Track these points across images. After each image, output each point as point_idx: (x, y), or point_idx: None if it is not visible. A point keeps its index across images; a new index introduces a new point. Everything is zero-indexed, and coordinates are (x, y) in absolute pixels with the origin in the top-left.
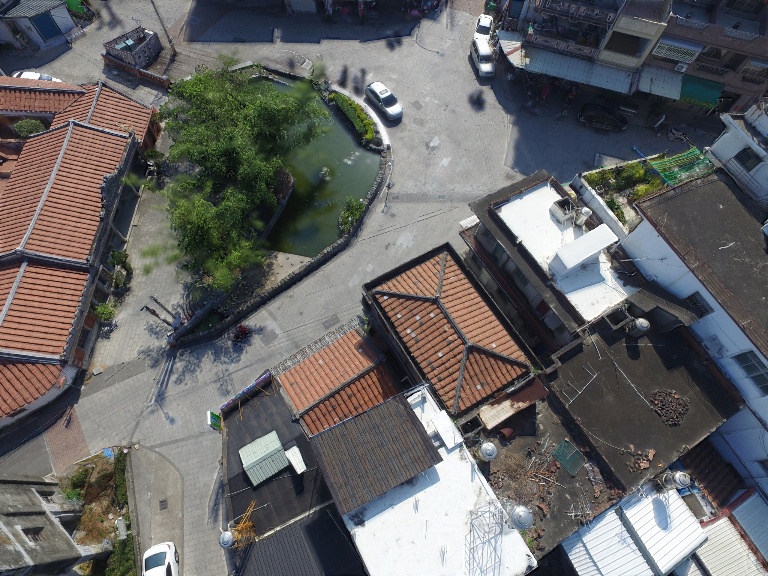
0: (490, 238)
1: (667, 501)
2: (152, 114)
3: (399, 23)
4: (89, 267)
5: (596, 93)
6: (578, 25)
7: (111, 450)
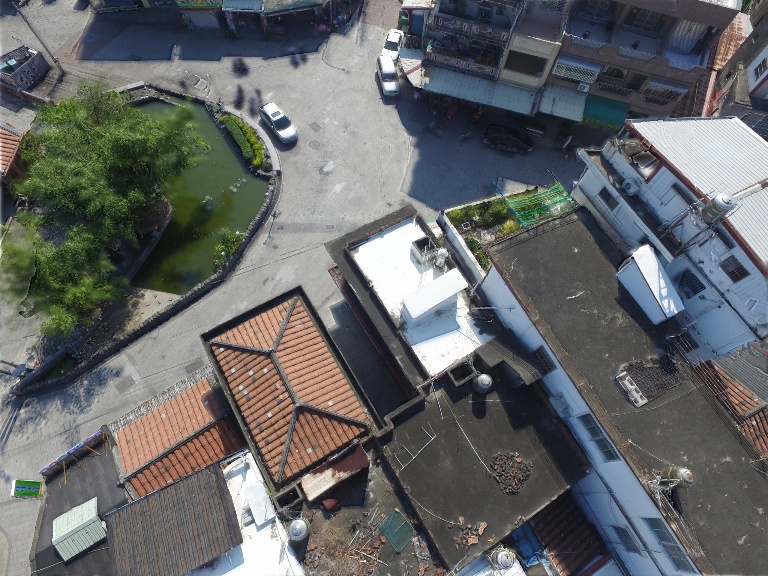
0: None
1: None
2: None
3: (306, 38)
4: None
5: (504, 112)
6: (477, 43)
7: None
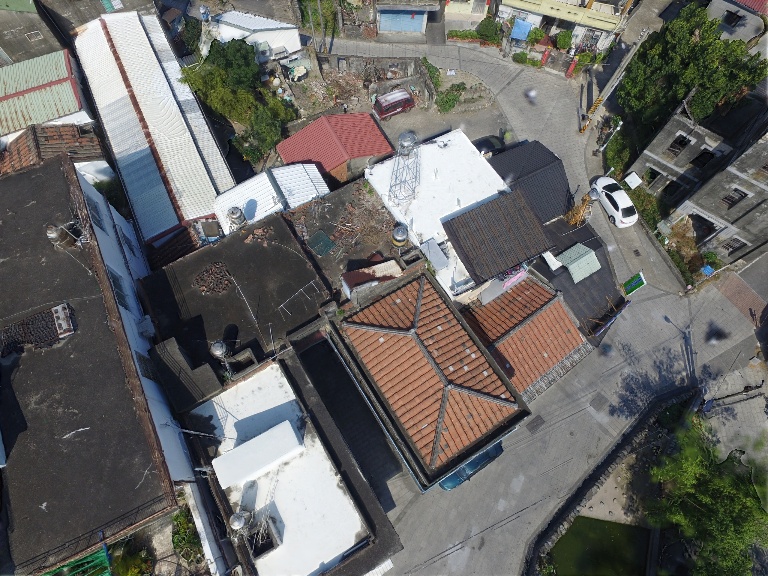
0: None
1: None
2: None
3: None
4: None
5: None
6: None
7: None
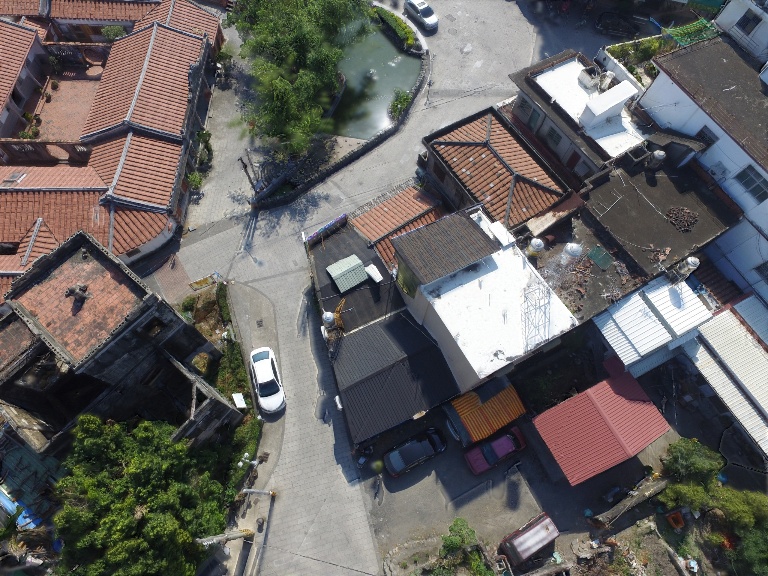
0: (526, 108)
1: (680, 290)
2: (219, 23)
3: None
4: (182, 140)
5: (611, 6)
6: None
7: (216, 278)
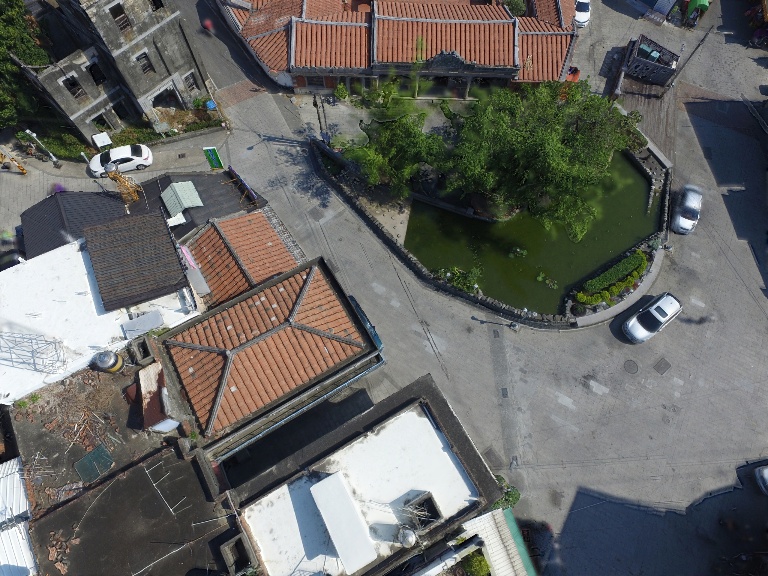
0: None
1: None
2: None
3: None
4: (371, 67)
5: None
6: None
7: None
